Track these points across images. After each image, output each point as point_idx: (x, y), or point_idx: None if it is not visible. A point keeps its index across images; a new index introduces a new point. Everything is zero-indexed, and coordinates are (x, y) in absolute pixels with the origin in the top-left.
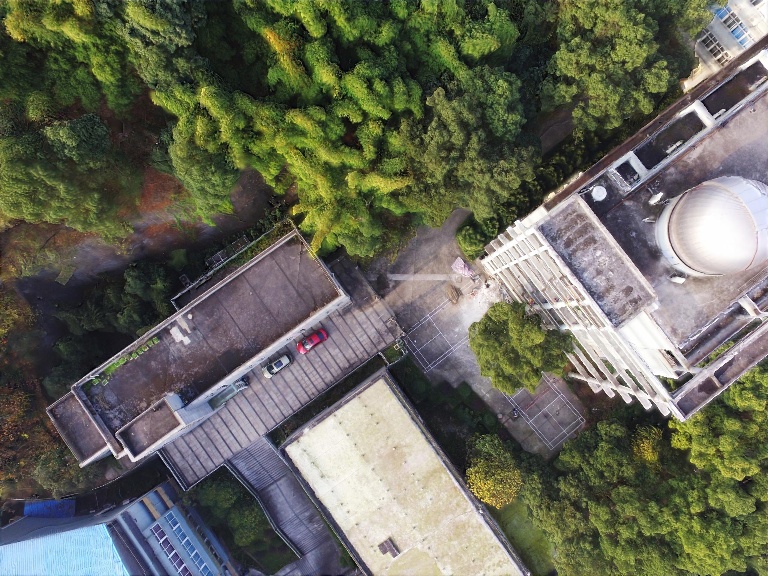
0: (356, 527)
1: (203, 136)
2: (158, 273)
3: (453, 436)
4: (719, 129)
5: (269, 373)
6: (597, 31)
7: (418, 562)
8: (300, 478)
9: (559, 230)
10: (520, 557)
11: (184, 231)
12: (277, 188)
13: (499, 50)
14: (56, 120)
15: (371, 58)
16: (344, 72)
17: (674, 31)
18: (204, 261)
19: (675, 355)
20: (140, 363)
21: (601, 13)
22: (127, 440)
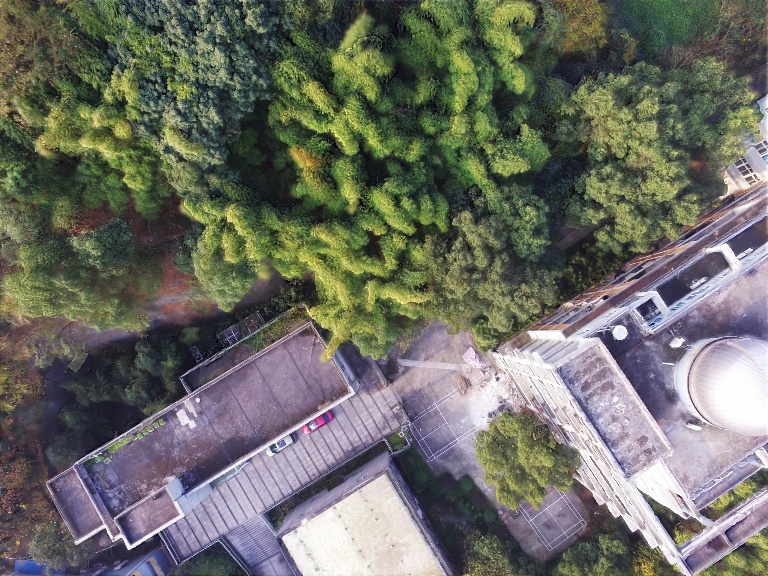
0: None
1: (228, 251)
2: (169, 349)
3: (451, 527)
4: (745, 275)
5: (271, 451)
6: (628, 162)
7: None
8: (295, 569)
9: (577, 373)
10: None
11: (198, 308)
12: None
13: None
14: (83, 229)
15: (400, 173)
16: (372, 187)
17: (705, 161)
18: (216, 334)
19: (686, 502)
20: (144, 444)
21: (634, 146)
22: (125, 526)
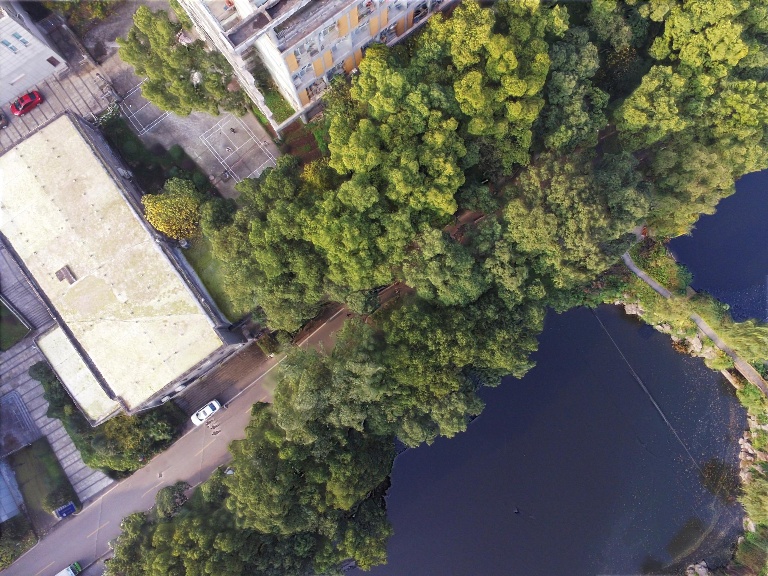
0: (35, 255)
1: None
2: None
3: None
4: None
5: None
6: None
7: (94, 288)
8: None
9: None
10: (215, 301)
11: None
12: None
13: None
14: None
15: None
16: None
17: None
18: None
19: None
20: None
21: None
22: None
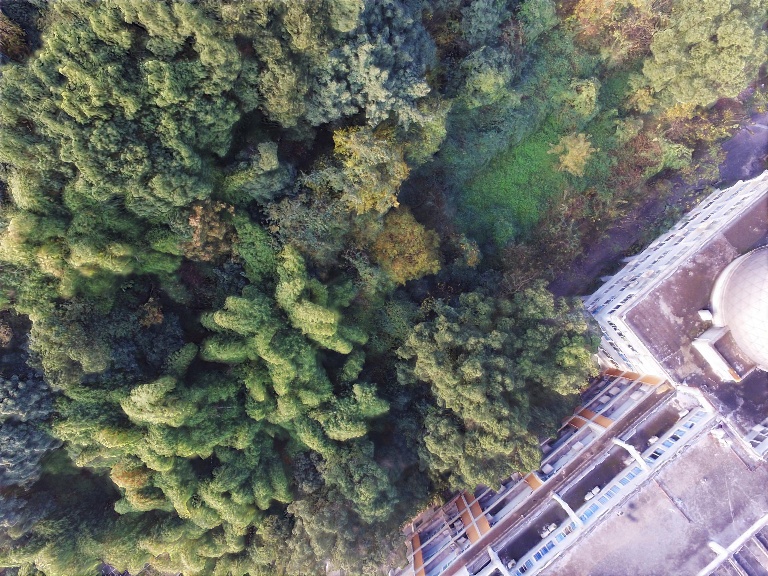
0: None
1: None
2: None
3: None
4: (586, 536)
5: None
6: (464, 417)
7: None
8: None
9: None
10: None
11: None
12: None
13: (371, 415)
14: None
15: (230, 460)
16: (199, 485)
17: (550, 389)
18: None
19: None
20: None
21: None
22: None
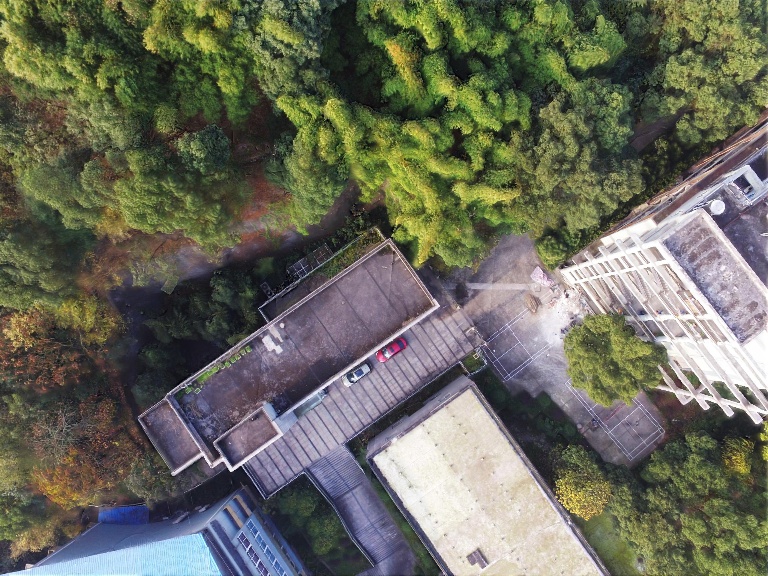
0: (444, 538)
1: (327, 148)
2: (245, 281)
3: (531, 446)
4: None
5: (349, 381)
6: (708, 44)
7: (507, 573)
8: (388, 488)
9: (683, 244)
10: None
11: (270, 239)
12: (363, 197)
13: None
14: (185, 131)
15: (482, 70)
16: None
17: None
18: (285, 269)
19: None
20: (232, 372)
21: (714, 26)
22: (224, 449)
